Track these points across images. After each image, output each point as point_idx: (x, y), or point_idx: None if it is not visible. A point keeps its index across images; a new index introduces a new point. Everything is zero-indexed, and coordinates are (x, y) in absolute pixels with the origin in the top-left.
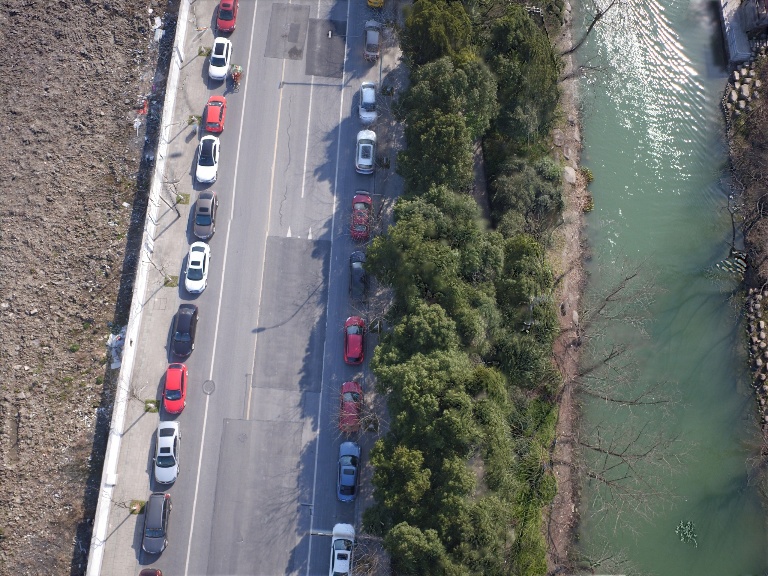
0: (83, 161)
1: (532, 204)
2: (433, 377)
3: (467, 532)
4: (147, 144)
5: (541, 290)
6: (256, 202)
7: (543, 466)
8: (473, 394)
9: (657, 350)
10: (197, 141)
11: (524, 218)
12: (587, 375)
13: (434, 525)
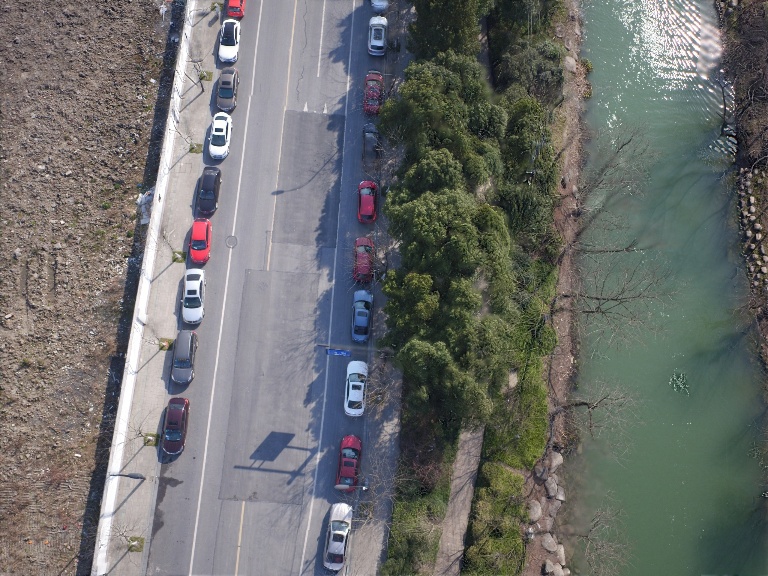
0: (113, 42)
1: (534, 79)
2: (441, 210)
3: (473, 342)
4: (172, 28)
5: (542, 156)
6: (275, 80)
7: (544, 317)
8: (478, 227)
9: (652, 222)
10: (219, 25)
11: (527, 91)
12: (586, 243)
13: (442, 338)
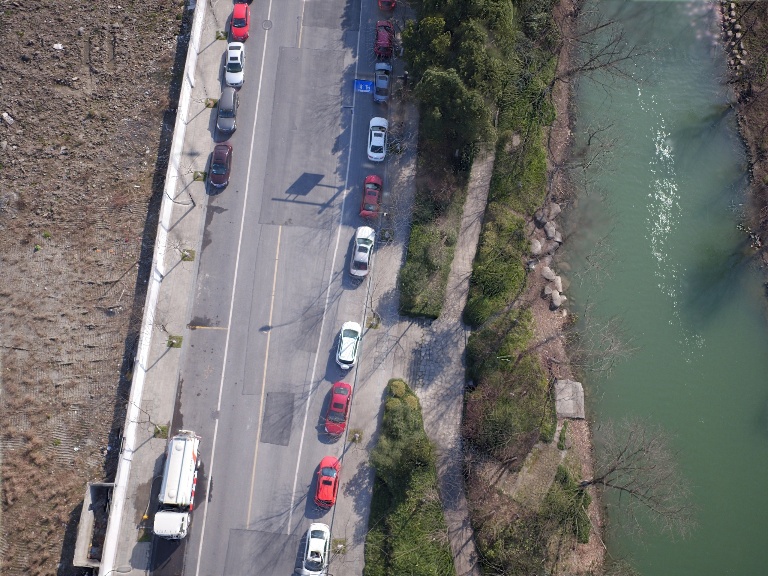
0: None
1: None
2: None
3: None
4: None
5: None
6: None
7: (544, 91)
8: None
9: (642, 25)
10: None
11: None
12: (582, 41)
13: (453, 65)
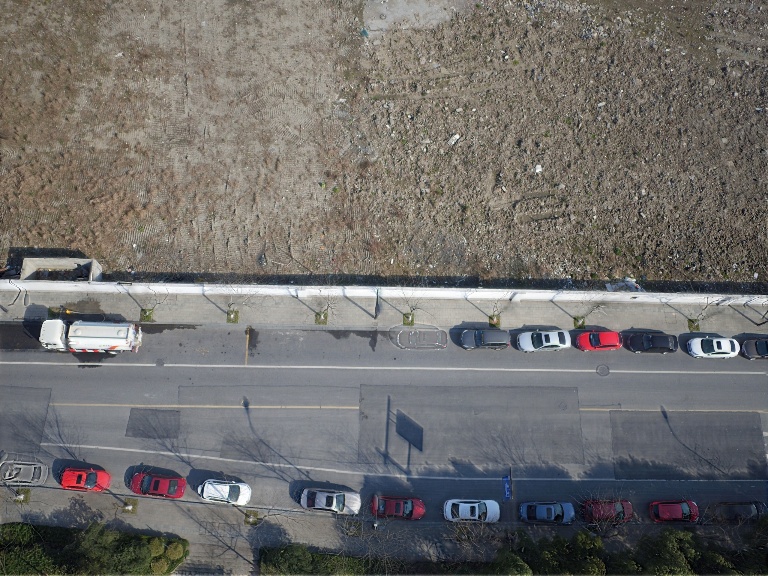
0: None
1: None
2: None
3: None
4: None
5: None
6: None
7: None
8: None
9: None
10: None
11: None
12: None
13: None
